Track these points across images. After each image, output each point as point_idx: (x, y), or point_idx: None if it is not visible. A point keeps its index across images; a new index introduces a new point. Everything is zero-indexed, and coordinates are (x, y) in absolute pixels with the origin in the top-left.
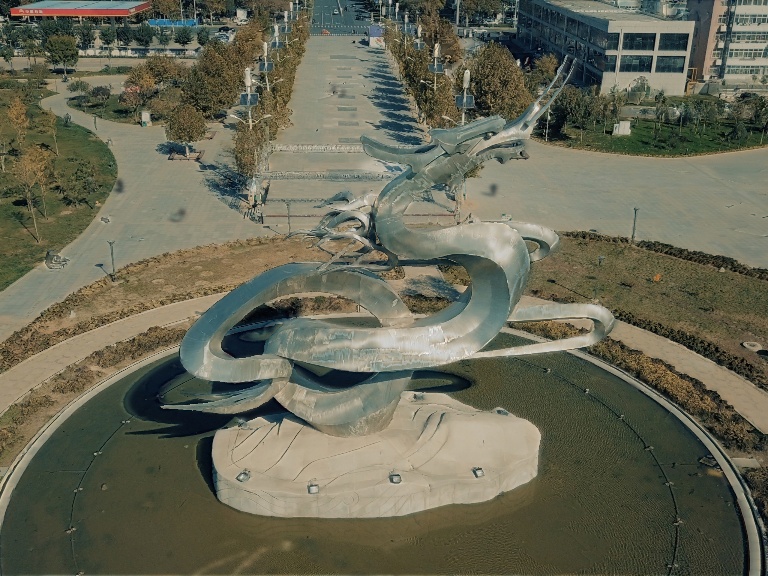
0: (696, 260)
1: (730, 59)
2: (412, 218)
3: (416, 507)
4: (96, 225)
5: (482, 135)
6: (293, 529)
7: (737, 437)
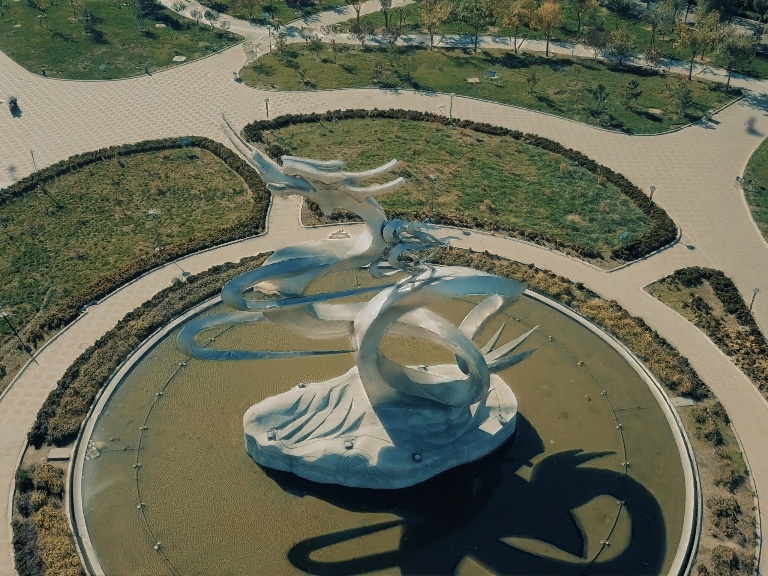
0: None
1: None
2: None
3: None
4: None
5: None
6: None
7: (50, 469)
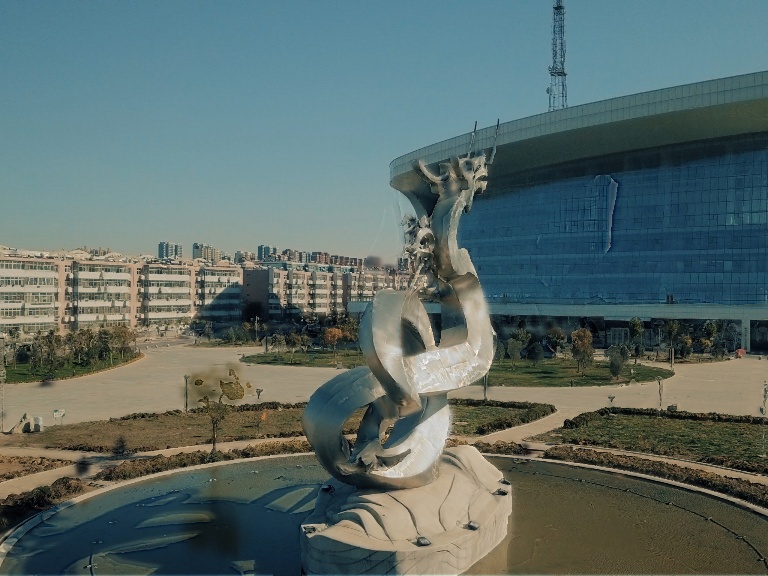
0: (253, 409)
1: None
2: None
3: None
4: None
5: None
6: None
7: (508, 446)
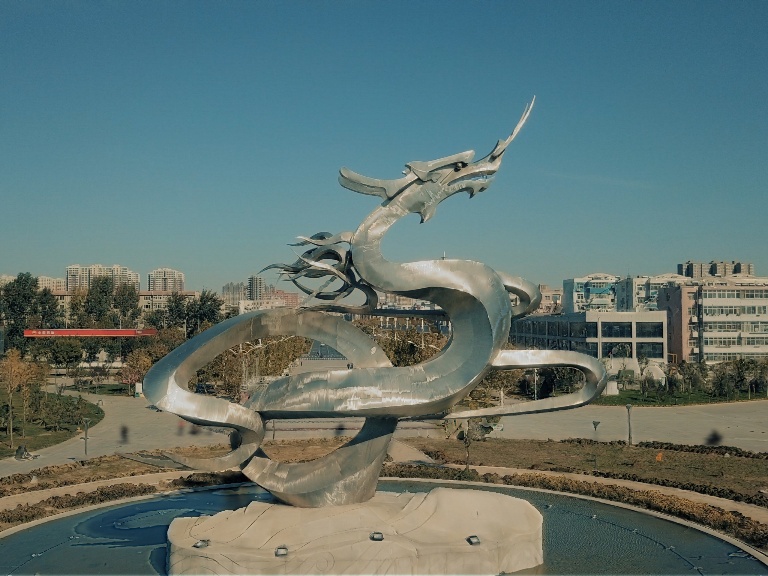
0: (698, 451)
1: (706, 347)
2: (401, 432)
3: None
4: (74, 440)
5: (452, 166)
6: None
7: (767, 534)
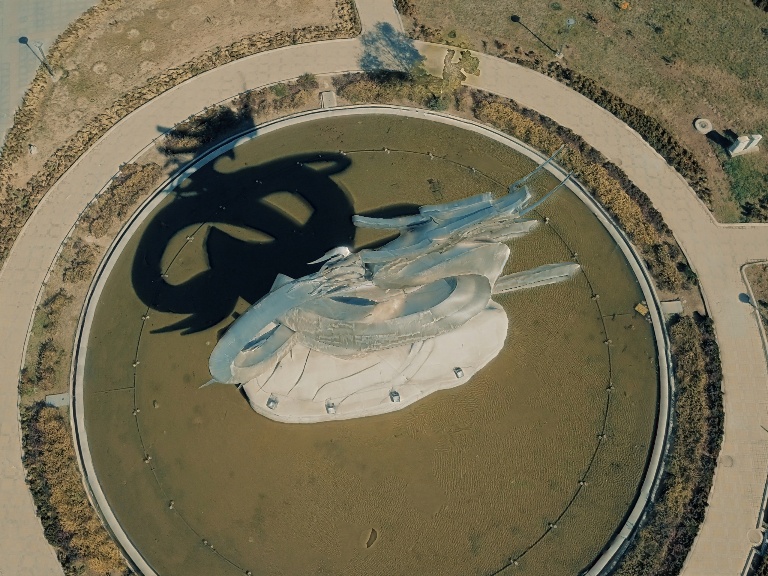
0: None
1: None
2: None
3: (411, 402)
4: None
5: None
6: (317, 425)
7: (669, 280)
